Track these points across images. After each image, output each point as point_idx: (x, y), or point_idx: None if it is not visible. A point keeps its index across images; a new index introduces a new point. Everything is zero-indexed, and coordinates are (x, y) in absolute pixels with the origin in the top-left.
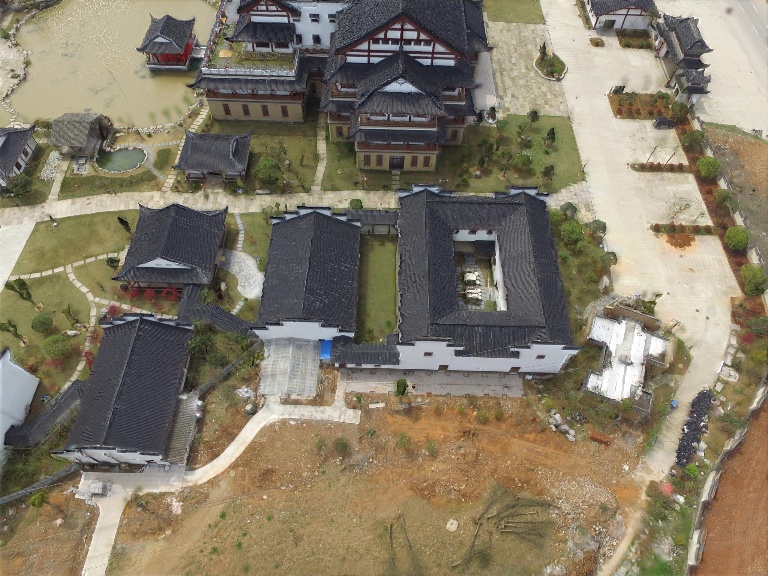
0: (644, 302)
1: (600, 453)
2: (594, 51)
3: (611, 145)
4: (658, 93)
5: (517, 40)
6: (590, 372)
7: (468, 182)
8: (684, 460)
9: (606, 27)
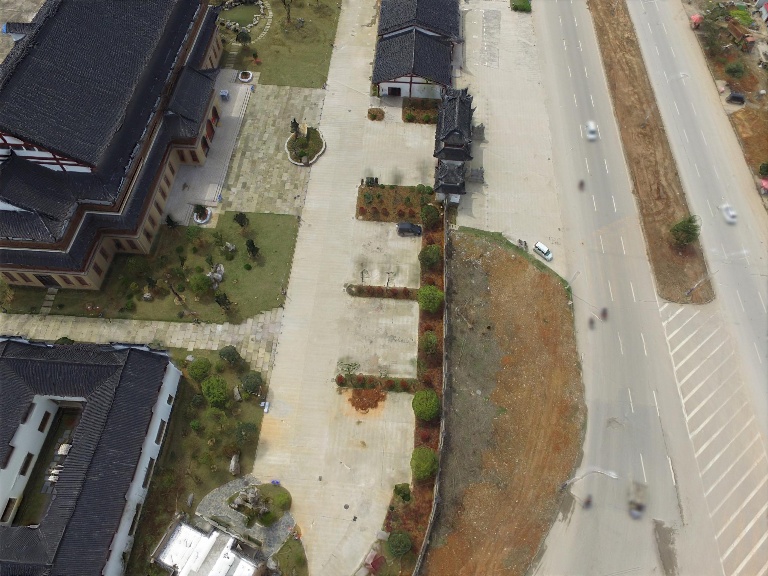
0: (245, 509)
1: None
2: (368, 126)
3: (335, 257)
4: (417, 187)
5: (281, 109)
6: None
7: (136, 306)
8: None
9: (392, 95)
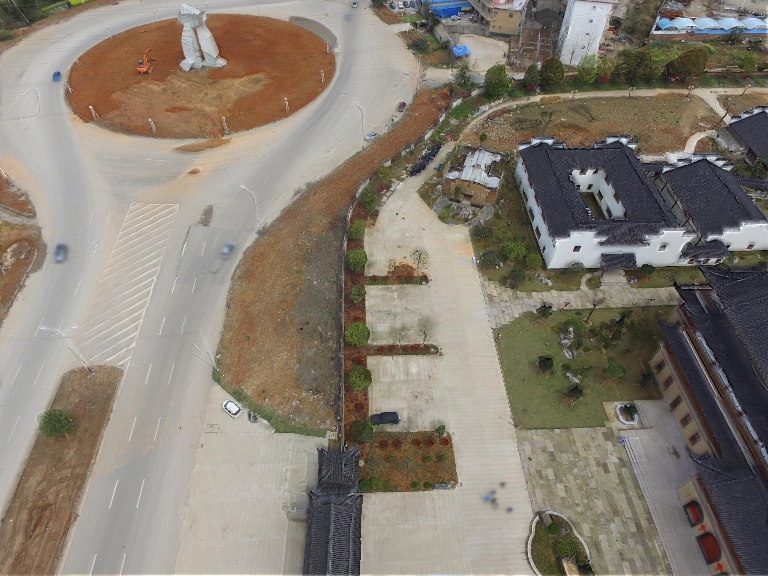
0: None
1: None
2: None
3: (460, 382)
4: None
5: None
6: None
7: None
8: (439, 144)
9: None
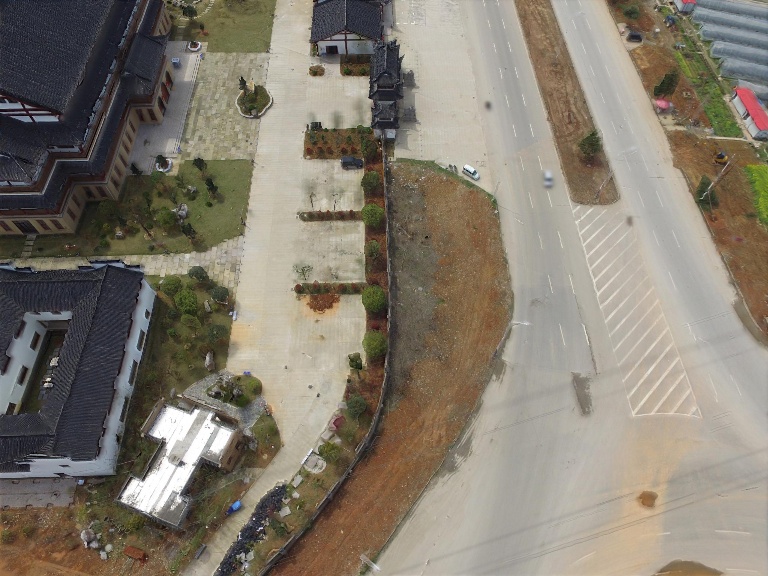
0: None
1: (132, 572)
2: (310, 81)
3: (287, 191)
4: (357, 128)
5: (230, 72)
6: (129, 478)
7: (109, 244)
8: None
9: (330, 53)
